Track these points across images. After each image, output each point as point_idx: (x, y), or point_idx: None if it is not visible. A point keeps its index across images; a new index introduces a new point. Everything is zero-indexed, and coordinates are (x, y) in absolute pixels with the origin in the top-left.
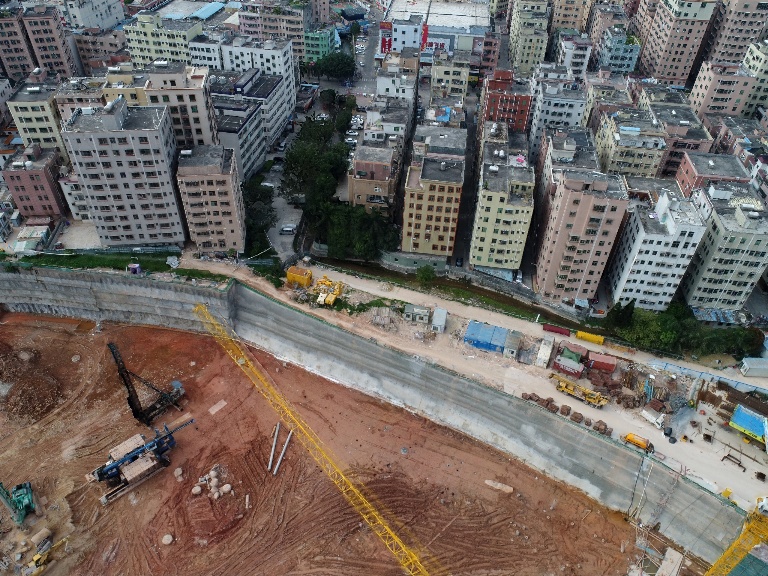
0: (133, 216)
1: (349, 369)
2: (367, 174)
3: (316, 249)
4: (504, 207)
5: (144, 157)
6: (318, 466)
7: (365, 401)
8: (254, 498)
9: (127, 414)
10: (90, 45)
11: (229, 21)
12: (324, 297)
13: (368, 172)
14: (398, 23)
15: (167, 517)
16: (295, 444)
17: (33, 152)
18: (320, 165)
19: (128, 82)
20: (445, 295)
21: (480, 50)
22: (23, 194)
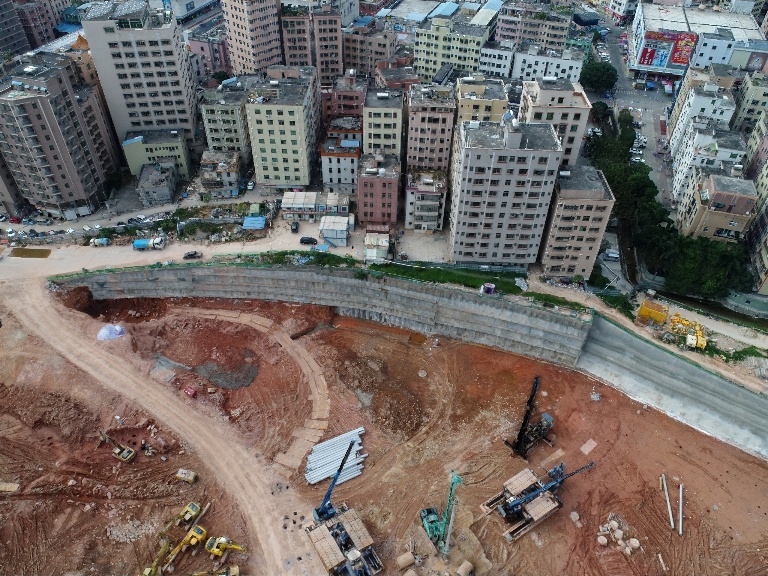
0: (496, 234)
1: (724, 422)
2: (725, 206)
3: (648, 280)
4: None
5: (535, 177)
6: (726, 532)
7: (750, 461)
8: (667, 559)
9: (497, 442)
10: (358, 44)
11: (475, 23)
12: (695, 340)
13: (727, 204)
14: (709, 37)
15: (580, 567)
16: (690, 502)
17: (384, 159)
18: (634, 187)
19: (480, 93)
20: None
21: (755, 66)
22: (369, 200)
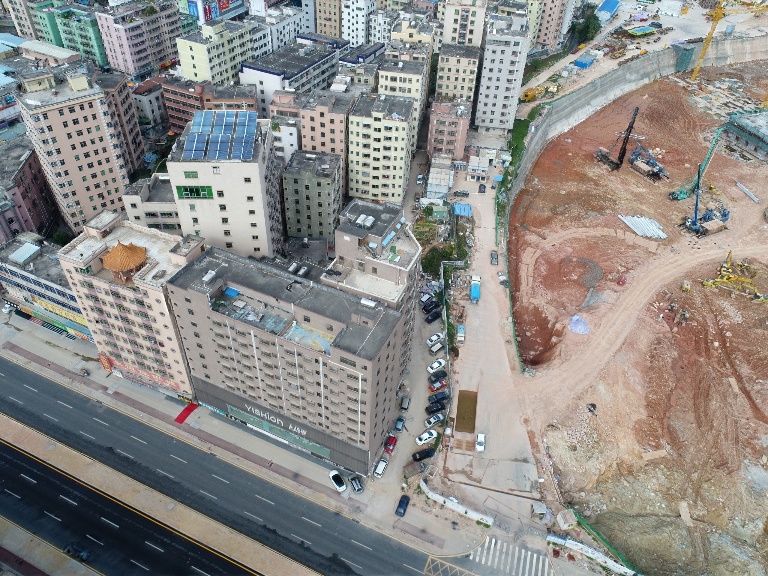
0: None
1: (582, 110)
2: None
3: None
4: (540, 7)
5: None
6: None
7: None
8: None
9: (611, 174)
10: None
11: (66, 54)
12: (554, 88)
13: None
14: None
15: None
16: None
17: None
18: None
19: None
20: (545, 68)
21: None
22: None
